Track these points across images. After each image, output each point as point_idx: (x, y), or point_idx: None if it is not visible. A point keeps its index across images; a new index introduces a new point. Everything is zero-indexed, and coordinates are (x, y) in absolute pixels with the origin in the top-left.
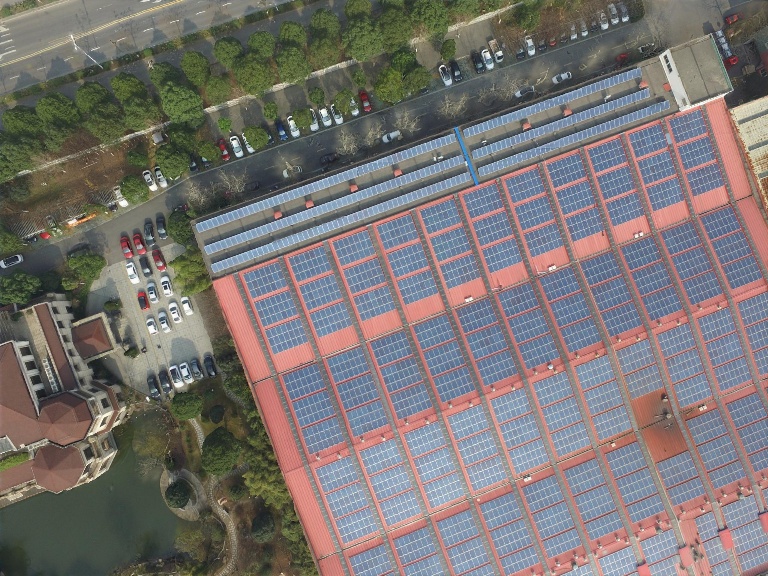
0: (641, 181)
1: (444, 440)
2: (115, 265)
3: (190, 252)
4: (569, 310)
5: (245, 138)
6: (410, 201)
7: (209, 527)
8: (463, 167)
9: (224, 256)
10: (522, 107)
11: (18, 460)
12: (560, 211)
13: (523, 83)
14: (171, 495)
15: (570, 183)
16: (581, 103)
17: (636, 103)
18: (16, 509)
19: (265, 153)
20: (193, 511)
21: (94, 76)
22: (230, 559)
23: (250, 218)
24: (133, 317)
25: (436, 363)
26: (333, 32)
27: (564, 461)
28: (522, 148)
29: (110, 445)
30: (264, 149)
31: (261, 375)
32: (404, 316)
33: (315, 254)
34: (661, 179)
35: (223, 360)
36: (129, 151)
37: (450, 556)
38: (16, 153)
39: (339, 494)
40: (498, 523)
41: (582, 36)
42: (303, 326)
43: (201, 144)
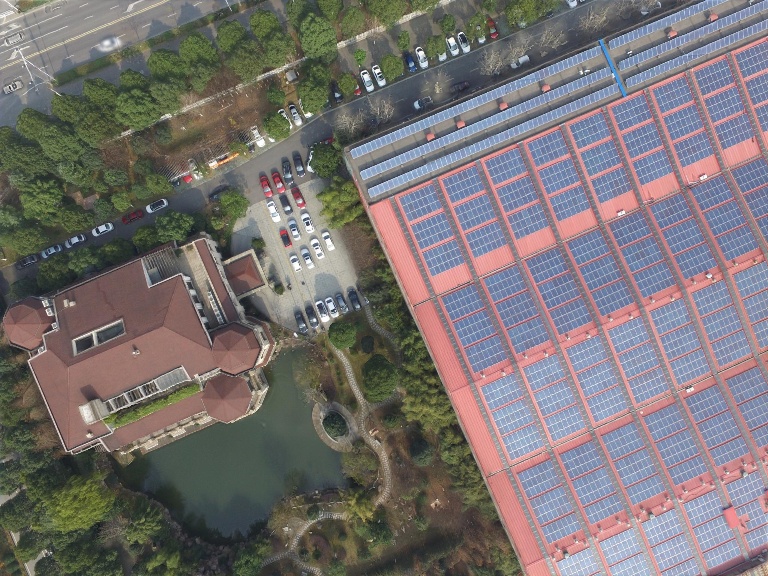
0: None
1: (606, 354)
2: (256, 205)
3: (337, 183)
4: (723, 218)
5: (376, 71)
6: (559, 116)
7: None
8: (609, 80)
9: (379, 181)
10: (666, 15)
11: (191, 391)
12: (709, 119)
13: None
14: (332, 423)
15: (718, 90)
16: (725, 8)
17: None
18: (175, 447)
19: (395, 86)
20: (346, 443)
21: (223, 19)
22: (385, 488)
23: (402, 142)
24: (276, 255)
25: (593, 278)
26: None
27: (725, 371)
28: (668, 57)
29: (263, 381)
30: (393, 82)
31: (420, 298)
32: (558, 233)
33: (468, 174)
34: None
35: (372, 290)
36: (268, 88)
37: (618, 468)
38: (167, 92)
39: (505, 411)
40: (663, 434)
41: None
42: (459, 247)
43: (342, 75)
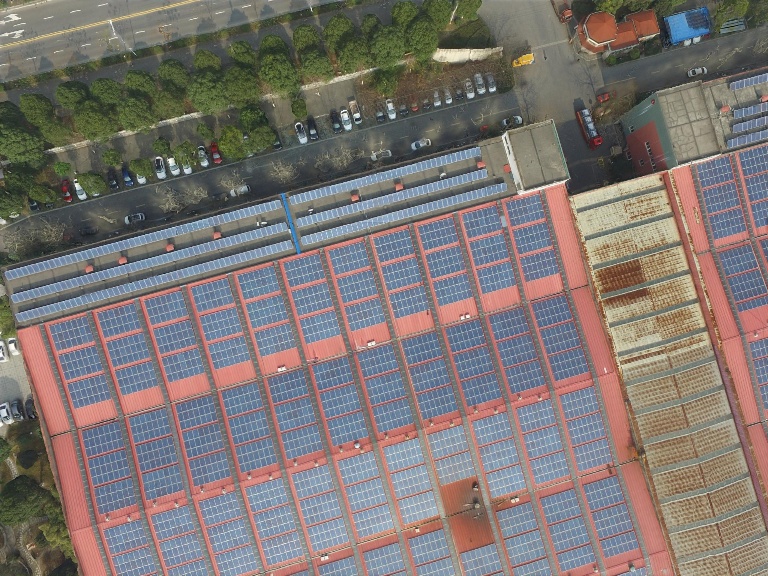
0: (472, 262)
1: (240, 511)
2: None
3: None
4: (384, 388)
5: None
6: (228, 265)
7: (14, 572)
8: (287, 234)
9: (32, 306)
10: (354, 178)
11: None
12: (384, 286)
13: (356, 154)
14: None
15: (397, 259)
16: (416, 178)
17: (473, 182)
18: None
19: (109, 197)
20: (1, 554)
21: None
22: None
23: (63, 269)
24: None
25: (240, 432)
26: (181, 83)
27: (365, 543)
28: (350, 219)
29: None
30: (109, 193)
31: (60, 429)
32: (213, 381)
33: (125, 311)
34: (493, 262)
35: None
36: None
37: None
38: None
39: (126, 557)
40: None
41: (446, 103)
42: (107, 383)
43: (31, 188)
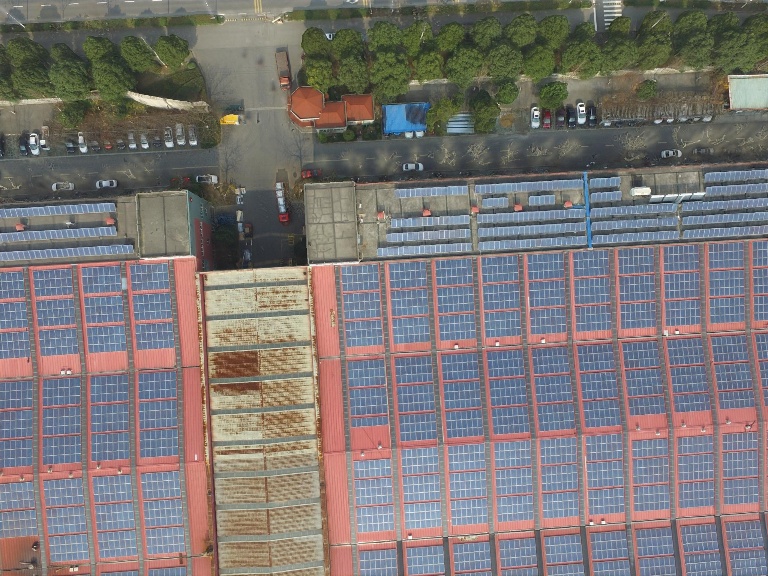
0: (84, 318)
1: None
2: None
3: None
4: None
5: None
6: None
7: None
8: None
9: None
10: None
11: None
12: None
13: None
14: None
15: (6, 299)
16: (44, 221)
17: (101, 238)
18: None
19: None
20: None
21: None
22: None
23: None
24: None
25: None
26: None
27: None
28: None
29: None
30: None
31: None
32: None
33: None
34: (106, 322)
35: None
36: None
37: None
38: None
39: None
40: None
41: (142, 148)
42: None
43: None
